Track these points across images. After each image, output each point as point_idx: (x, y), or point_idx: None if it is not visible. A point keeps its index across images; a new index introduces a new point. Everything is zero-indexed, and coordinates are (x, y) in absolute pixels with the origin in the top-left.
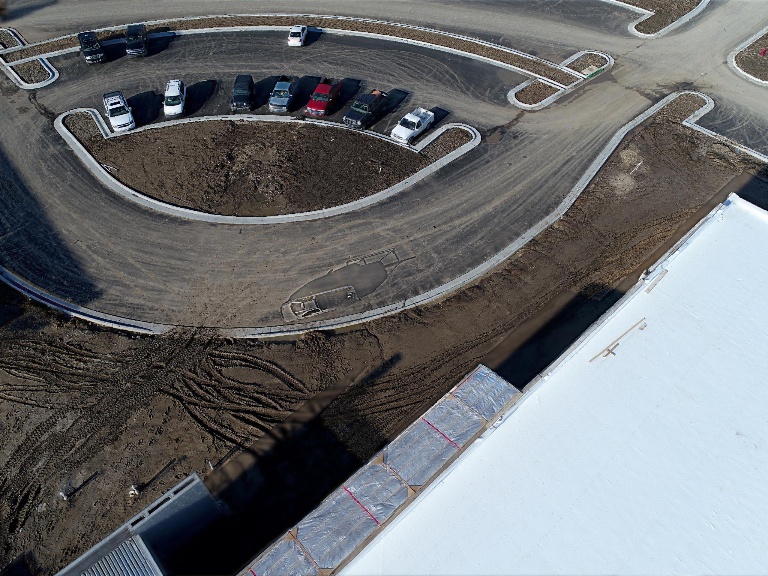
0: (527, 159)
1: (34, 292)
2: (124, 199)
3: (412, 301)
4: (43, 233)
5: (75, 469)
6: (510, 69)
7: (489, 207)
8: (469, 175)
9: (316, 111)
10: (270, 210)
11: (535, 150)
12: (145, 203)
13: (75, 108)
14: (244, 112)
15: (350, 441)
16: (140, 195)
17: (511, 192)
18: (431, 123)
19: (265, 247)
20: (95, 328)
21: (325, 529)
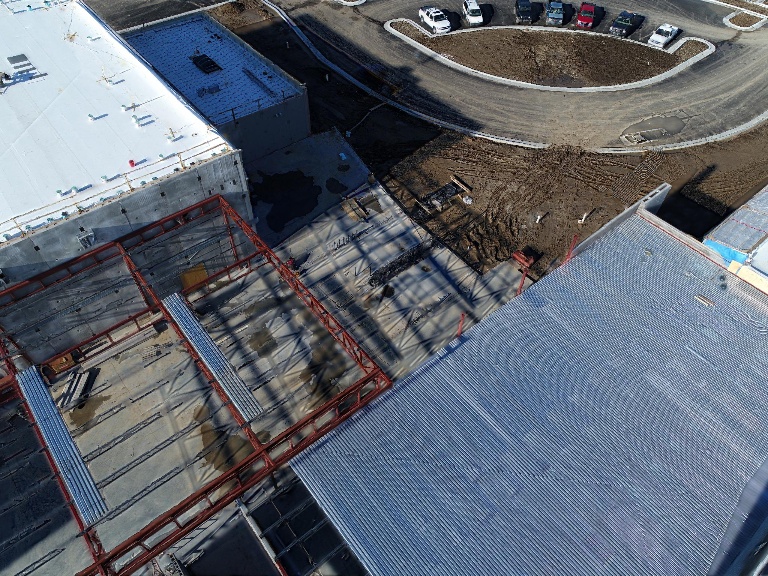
0: (757, 61)
1: (441, 123)
2: (468, 74)
3: (711, 138)
4: (423, 91)
5: (533, 210)
6: (718, 4)
7: (741, 88)
8: (717, 69)
9: (585, 24)
10: (578, 84)
11: (761, 56)
12: (485, 77)
13: (394, 18)
14: (526, 24)
15: (707, 205)
16: (479, 72)
17: (754, 80)
18: (674, 35)
19: (588, 105)
20: (496, 143)
21: (766, 205)
